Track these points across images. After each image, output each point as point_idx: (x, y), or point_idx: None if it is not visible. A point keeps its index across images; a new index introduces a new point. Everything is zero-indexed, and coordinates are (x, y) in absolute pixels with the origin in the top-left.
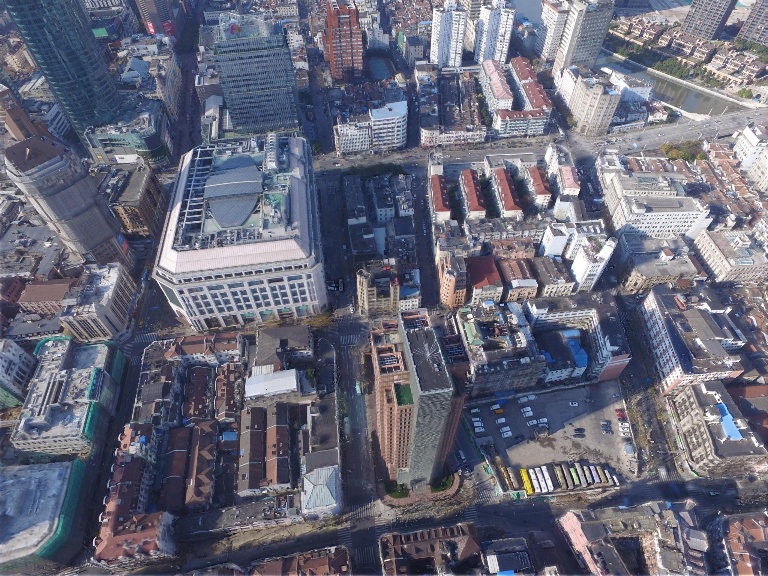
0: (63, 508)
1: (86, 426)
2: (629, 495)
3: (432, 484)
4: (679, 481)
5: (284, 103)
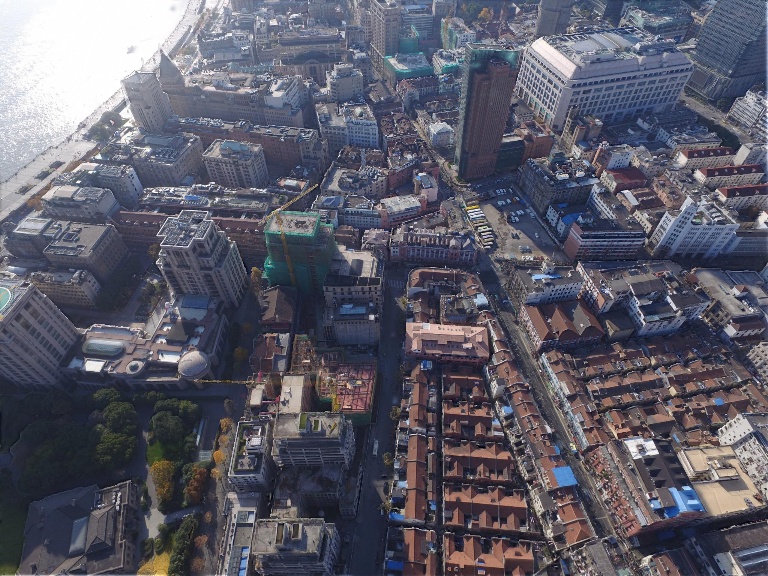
0: (413, 70)
1: (447, 66)
2: (480, 255)
3: (459, 175)
4: (499, 281)
5: (735, 51)
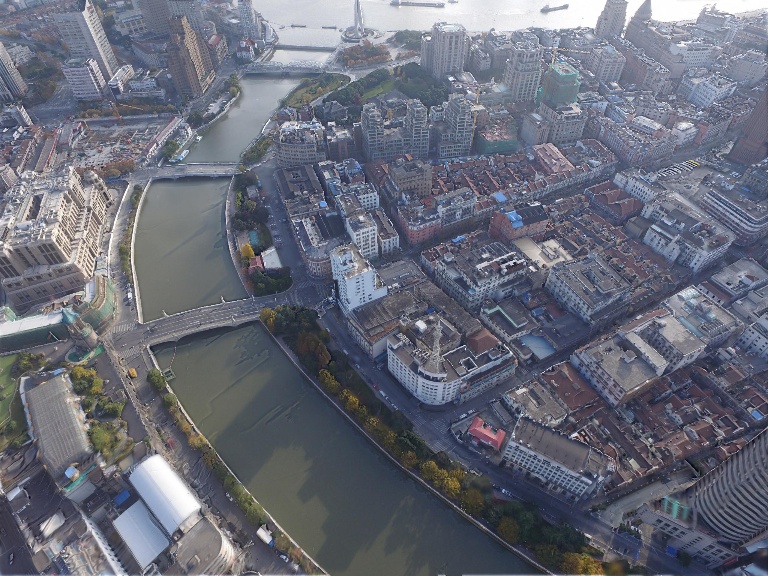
0: None
1: None
2: None
3: None
4: None
5: None
